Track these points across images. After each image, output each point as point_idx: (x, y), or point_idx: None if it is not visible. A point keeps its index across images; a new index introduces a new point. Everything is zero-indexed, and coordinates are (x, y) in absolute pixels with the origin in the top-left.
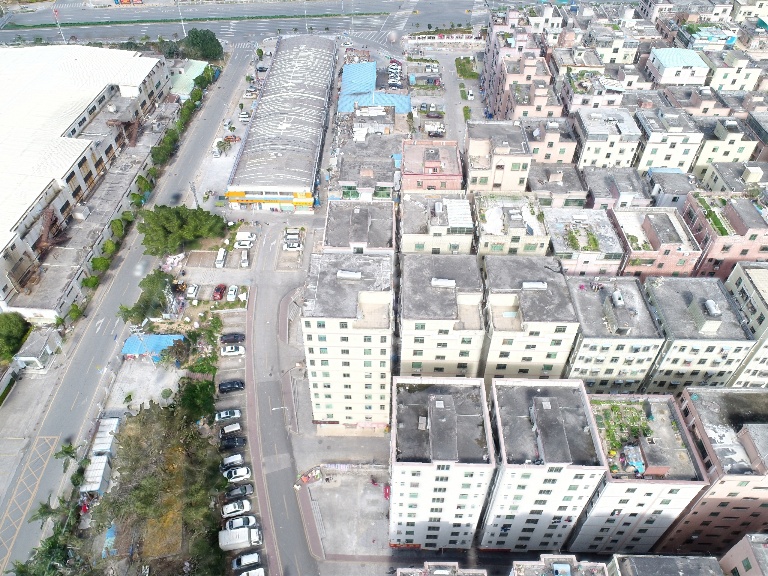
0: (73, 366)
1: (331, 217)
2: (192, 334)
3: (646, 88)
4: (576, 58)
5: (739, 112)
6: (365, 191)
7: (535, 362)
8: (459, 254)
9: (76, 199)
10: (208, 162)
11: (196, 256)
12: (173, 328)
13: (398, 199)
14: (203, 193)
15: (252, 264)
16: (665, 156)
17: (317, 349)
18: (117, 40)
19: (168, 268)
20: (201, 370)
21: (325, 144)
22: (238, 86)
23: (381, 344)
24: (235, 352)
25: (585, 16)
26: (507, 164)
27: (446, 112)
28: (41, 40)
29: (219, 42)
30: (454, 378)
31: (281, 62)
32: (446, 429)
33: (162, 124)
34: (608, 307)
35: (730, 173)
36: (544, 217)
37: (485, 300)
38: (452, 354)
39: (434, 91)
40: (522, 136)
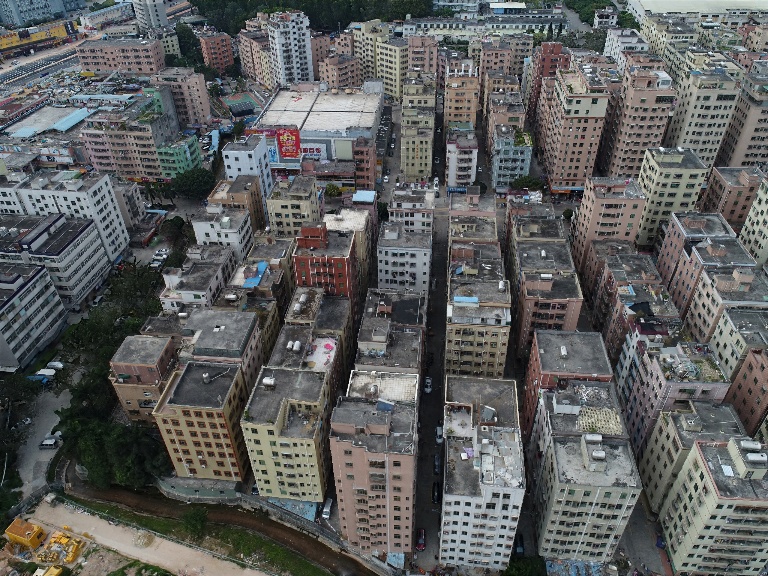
0: None
1: None
2: None
3: None
4: None
5: None
6: None
7: None
8: None
9: None
10: None
11: None
12: None
13: None
14: None
15: None
16: None
17: None
18: None
19: None
20: None
21: None
22: None
23: None
24: None
25: None
26: None
27: None
28: None
29: None
30: None
31: None
32: None
33: None
34: None
35: None
36: None
37: None
38: None
39: None
40: None
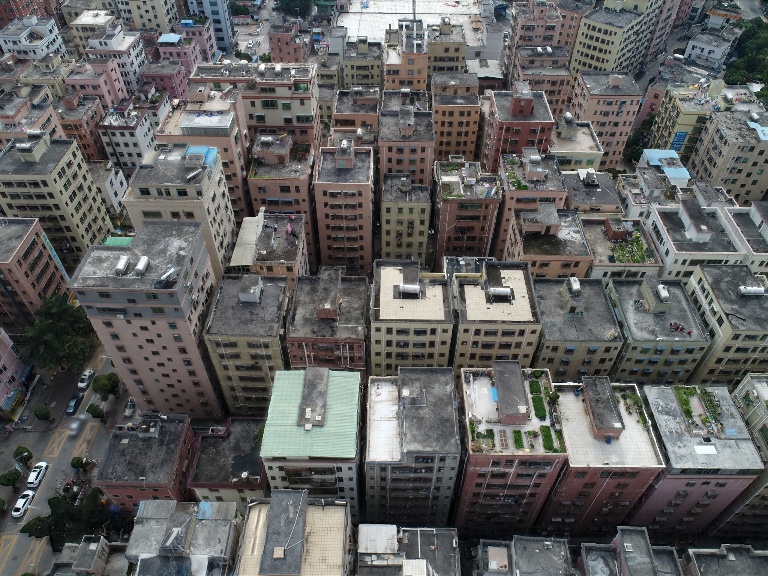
0: None
1: None
2: None
3: None
4: None
5: None
6: None
7: None
8: None
9: None
10: None
11: None
12: None
13: None
14: None
15: None
16: None
17: None
18: None
19: None
20: None
21: None
22: None
23: None
24: None
25: None
26: None
27: None
28: None
29: None
30: None
31: None
32: None
33: None
34: None
35: None
36: None
37: None
38: None
39: None
40: None
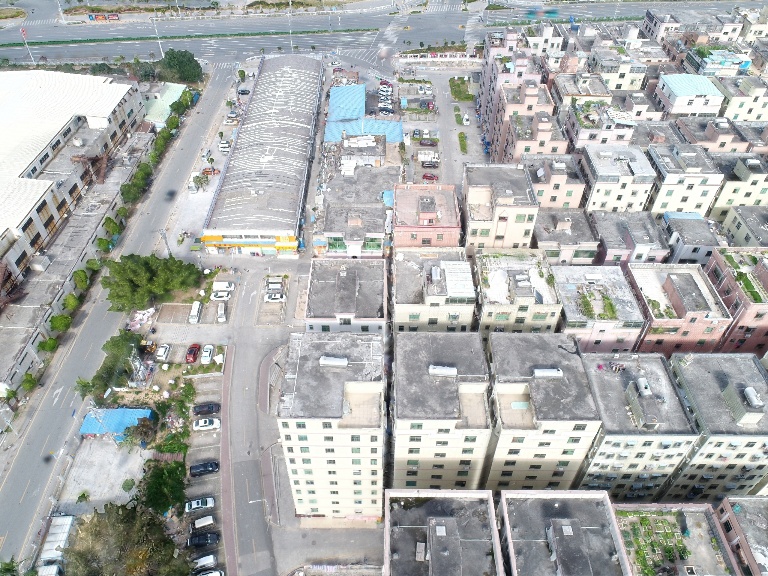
0: (25, 447)
1: (314, 279)
2: (161, 405)
3: (656, 118)
4: (581, 86)
5: (759, 146)
6: (353, 244)
7: (549, 458)
8: (459, 325)
9: (35, 248)
10: (184, 198)
11: (168, 310)
12: (140, 398)
13: (390, 242)
14: (178, 235)
15: (230, 318)
16: (681, 198)
17: (297, 448)
18: (90, 60)
19: (136, 326)
20: (170, 450)
21: (311, 177)
22: (218, 111)
23: (371, 443)
24: (209, 426)
25: (587, 36)
26: (511, 215)
27: (440, 139)
28: (8, 61)
29: (198, 63)
30: (457, 491)
31: (264, 85)
32: (449, 566)
33: (134, 157)
34: (632, 395)
35: (754, 219)
36: (554, 279)
37: (491, 387)
38: (453, 452)
39: (427, 115)
40: (527, 182)
